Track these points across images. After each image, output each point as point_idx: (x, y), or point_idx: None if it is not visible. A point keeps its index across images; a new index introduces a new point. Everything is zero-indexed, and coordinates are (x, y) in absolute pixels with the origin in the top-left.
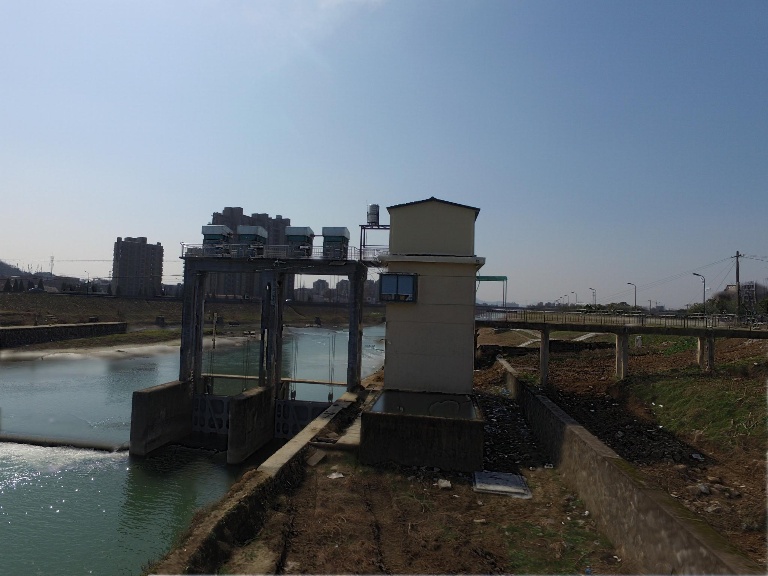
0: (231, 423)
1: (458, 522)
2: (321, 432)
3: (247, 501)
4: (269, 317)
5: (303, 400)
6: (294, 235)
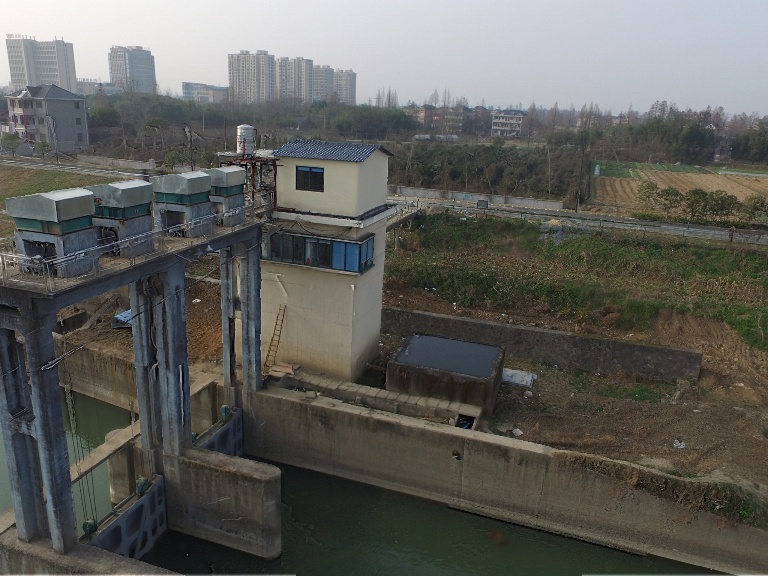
0: (277, 509)
1: (575, 402)
2: None
3: None
4: (182, 343)
5: (198, 438)
6: (199, 193)
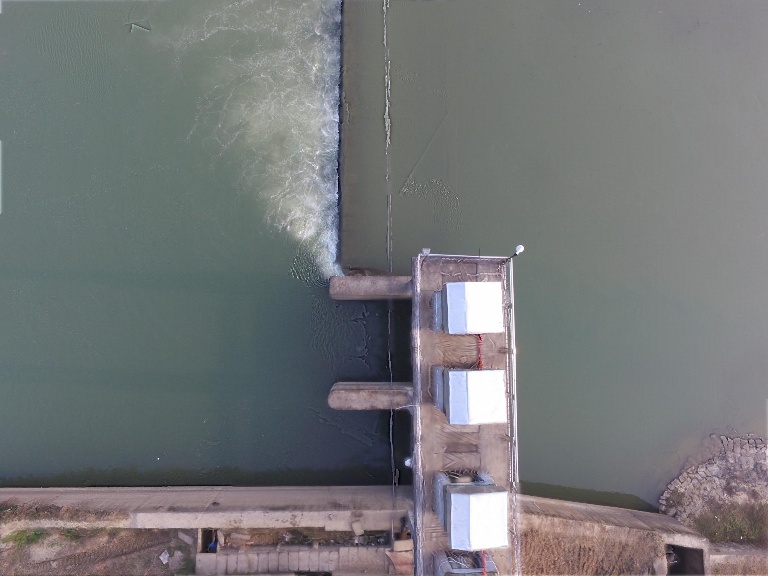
0: None
1: None
2: (232, 529)
3: (82, 529)
4: None
5: None
6: None
